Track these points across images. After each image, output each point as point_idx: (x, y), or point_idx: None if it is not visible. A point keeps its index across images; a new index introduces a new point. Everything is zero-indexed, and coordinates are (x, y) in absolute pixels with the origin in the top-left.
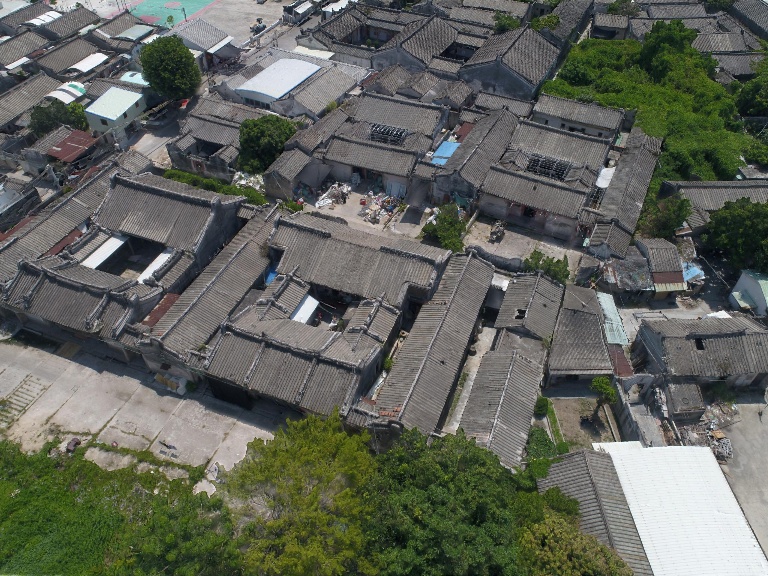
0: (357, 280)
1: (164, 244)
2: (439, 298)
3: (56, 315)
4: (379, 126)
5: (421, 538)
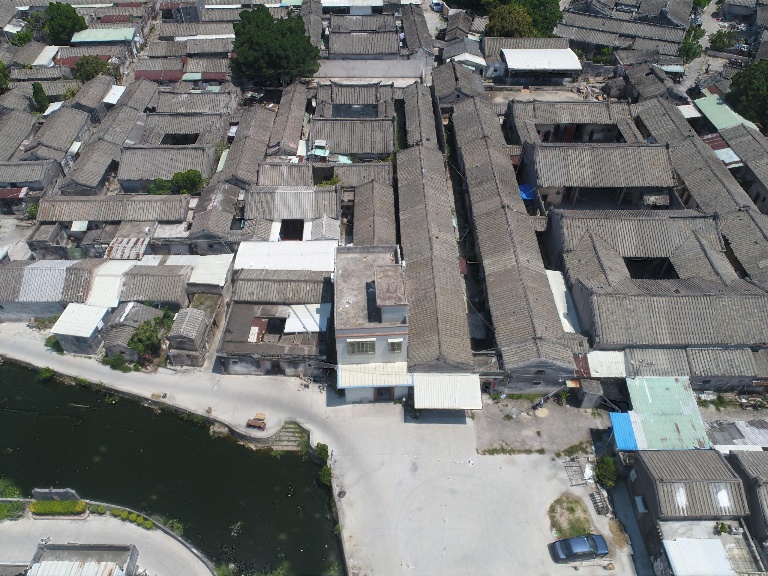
0: None
1: None
2: None
3: None
4: None
5: None
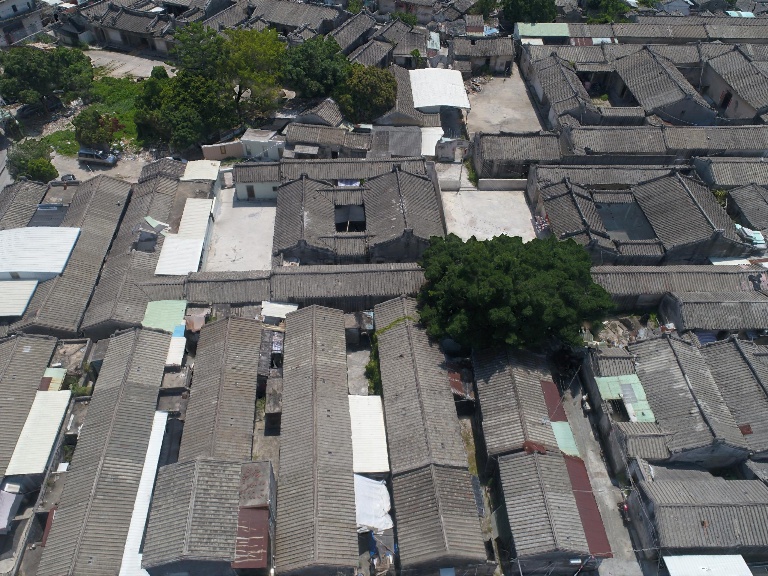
0: (295, 19)
1: (188, 7)
2: (340, 27)
3: (129, 27)
4: None
5: (300, 49)
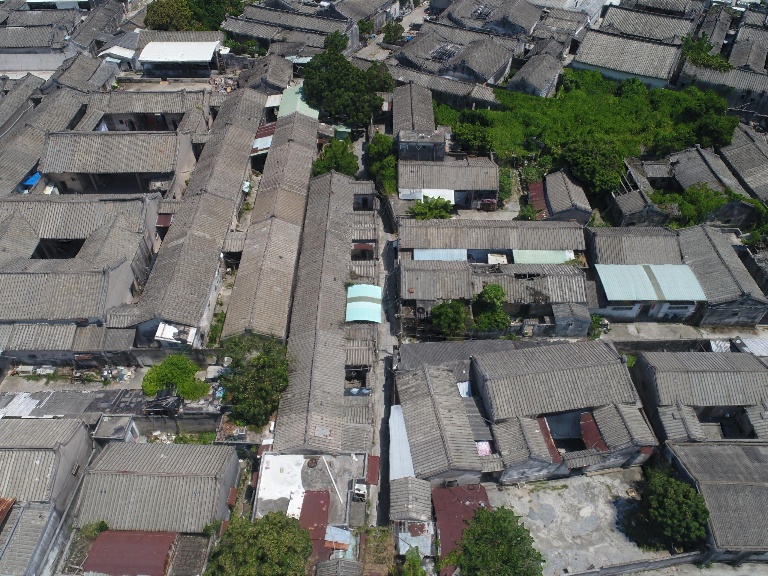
0: None
1: None
2: None
3: None
4: (487, 8)
5: None
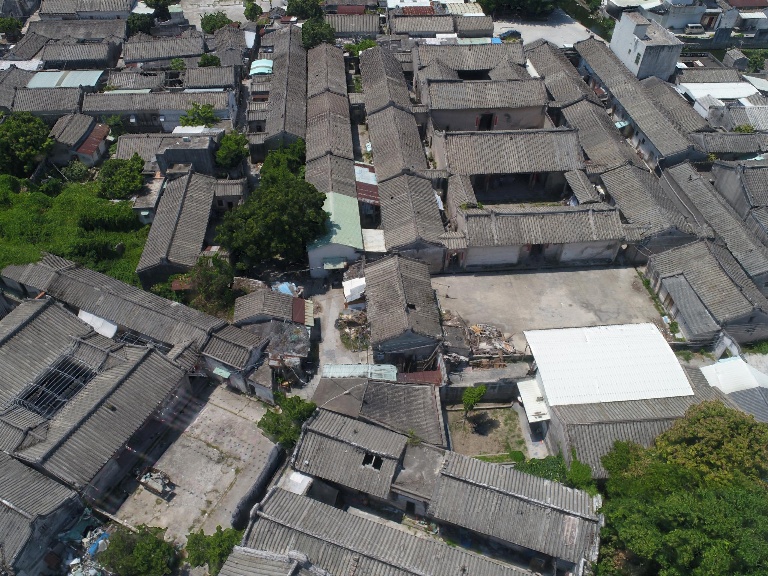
0: None
1: None
2: (341, 571)
3: None
4: None
5: None
